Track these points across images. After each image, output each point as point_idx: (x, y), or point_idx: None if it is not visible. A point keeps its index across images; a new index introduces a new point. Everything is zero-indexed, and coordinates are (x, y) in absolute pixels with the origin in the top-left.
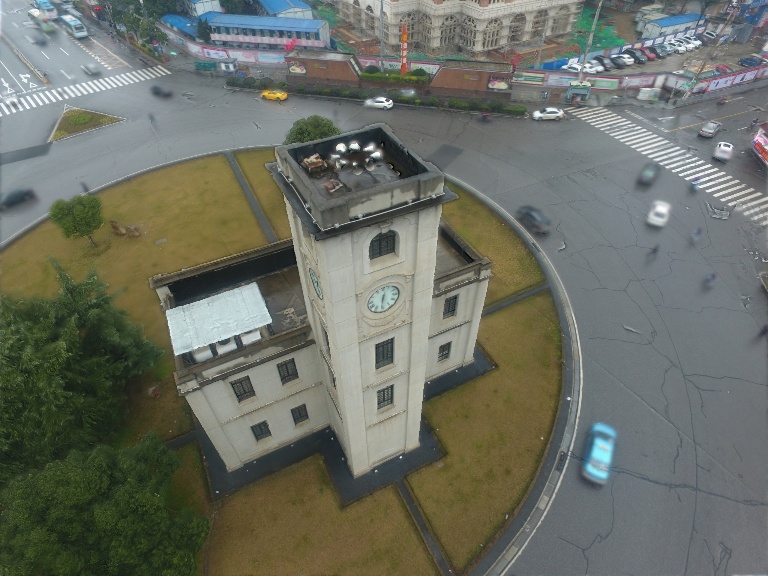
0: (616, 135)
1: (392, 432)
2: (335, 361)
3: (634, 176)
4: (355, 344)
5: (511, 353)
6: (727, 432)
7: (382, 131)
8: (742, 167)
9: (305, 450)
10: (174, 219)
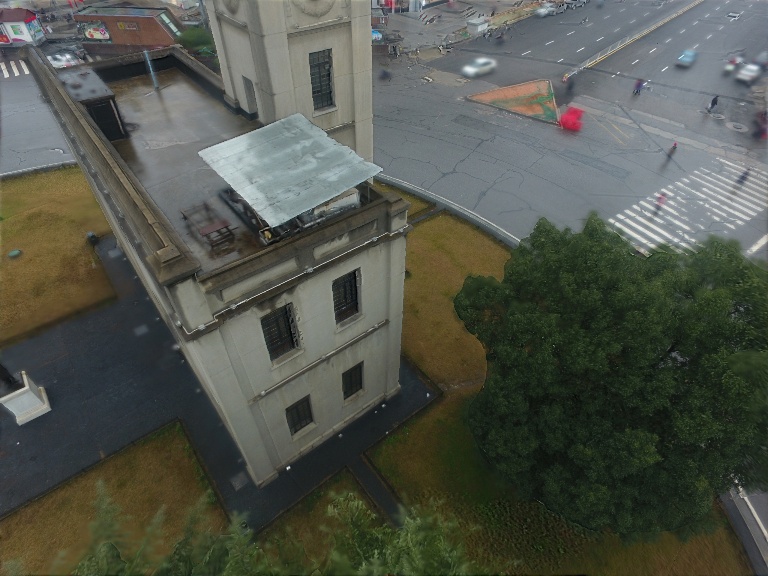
0: None
1: None
2: (362, 59)
3: None
4: None
5: None
6: None
7: None
8: None
9: None
10: None
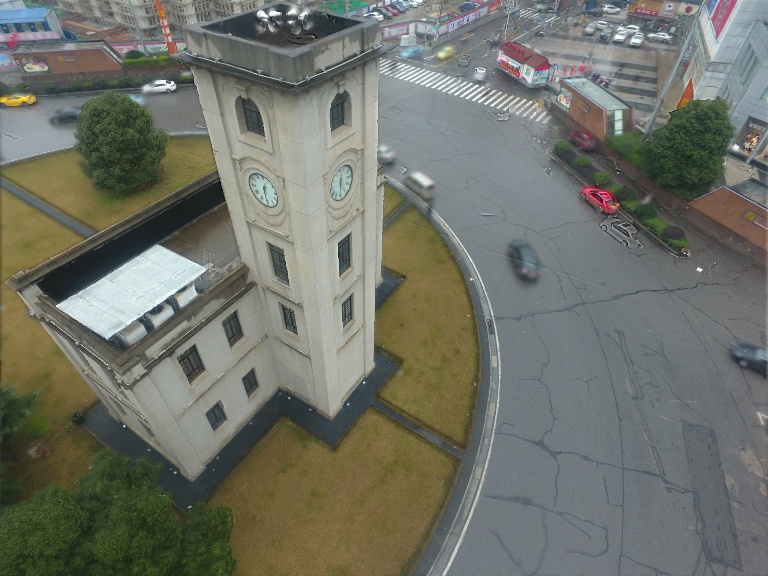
0: (399, 76)
1: (354, 355)
2: (305, 273)
3: (429, 104)
4: (325, 242)
5: (410, 262)
6: (582, 259)
7: (284, 6)
8: (498, 82)
9: (267, 421)
10: None
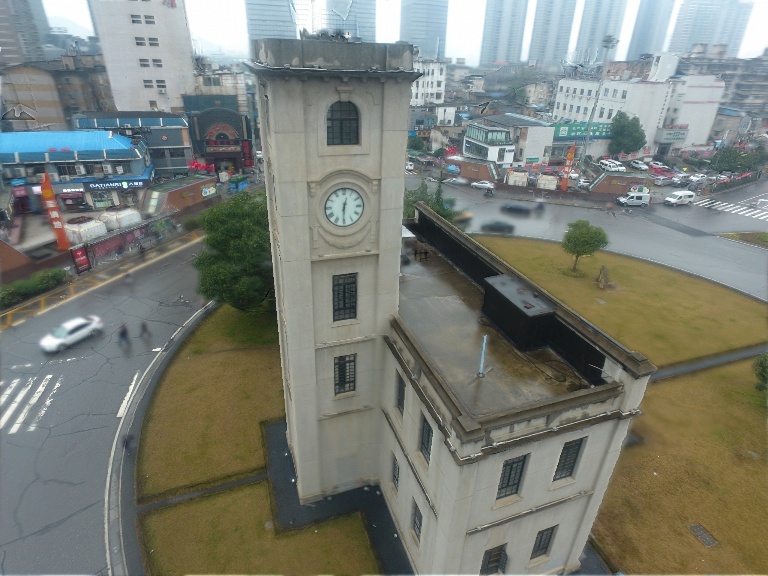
0: None
1: None
2: None
3: None
4: None
5: None
6: None
7: None
8: None
9: None
10: (640, 304)
